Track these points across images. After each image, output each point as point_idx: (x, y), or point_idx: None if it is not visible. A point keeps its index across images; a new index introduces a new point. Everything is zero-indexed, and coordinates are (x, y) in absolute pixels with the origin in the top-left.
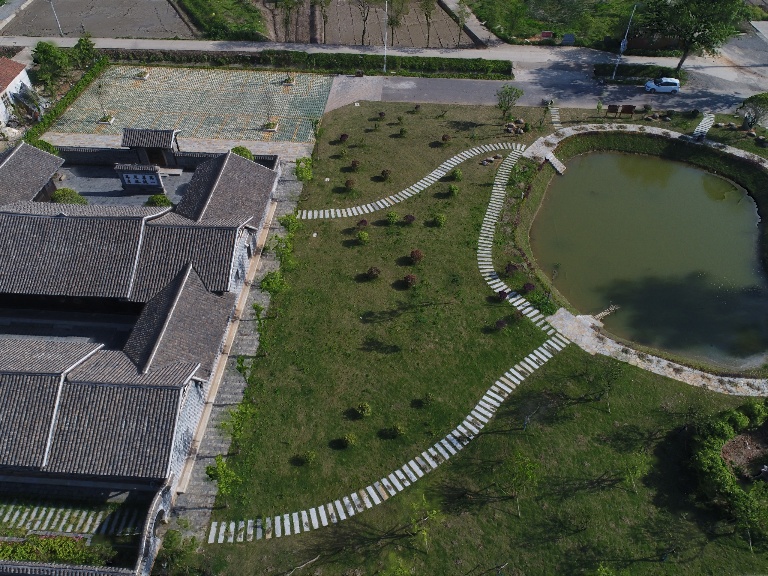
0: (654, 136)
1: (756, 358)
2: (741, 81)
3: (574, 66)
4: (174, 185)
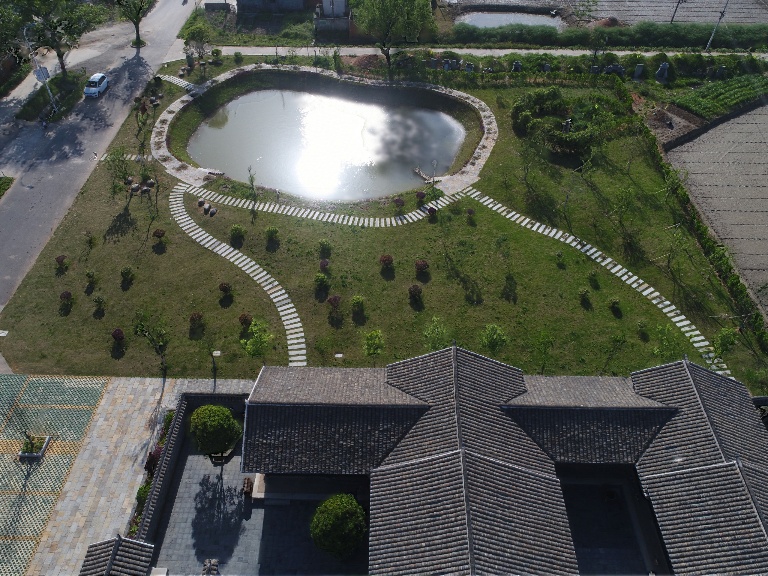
0: (185, 109)
1: (453, 124)
2: (105, 50)
3: (8, 131)
4: (198, 573)
